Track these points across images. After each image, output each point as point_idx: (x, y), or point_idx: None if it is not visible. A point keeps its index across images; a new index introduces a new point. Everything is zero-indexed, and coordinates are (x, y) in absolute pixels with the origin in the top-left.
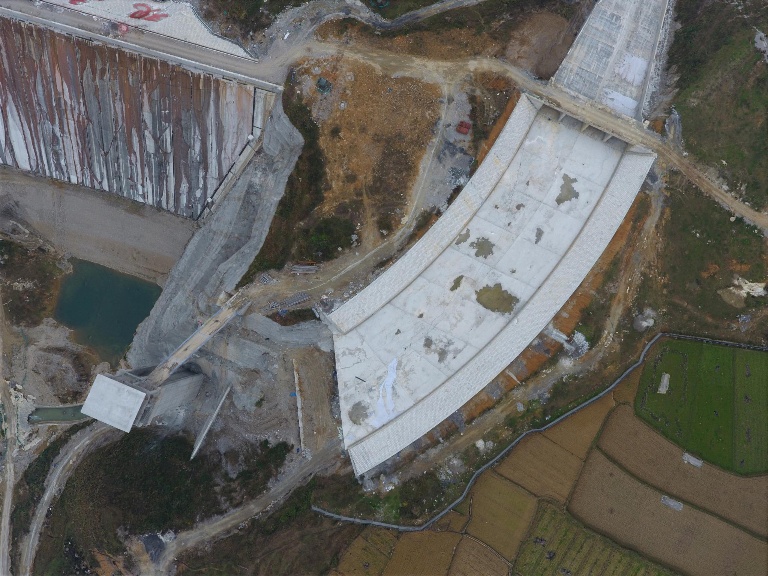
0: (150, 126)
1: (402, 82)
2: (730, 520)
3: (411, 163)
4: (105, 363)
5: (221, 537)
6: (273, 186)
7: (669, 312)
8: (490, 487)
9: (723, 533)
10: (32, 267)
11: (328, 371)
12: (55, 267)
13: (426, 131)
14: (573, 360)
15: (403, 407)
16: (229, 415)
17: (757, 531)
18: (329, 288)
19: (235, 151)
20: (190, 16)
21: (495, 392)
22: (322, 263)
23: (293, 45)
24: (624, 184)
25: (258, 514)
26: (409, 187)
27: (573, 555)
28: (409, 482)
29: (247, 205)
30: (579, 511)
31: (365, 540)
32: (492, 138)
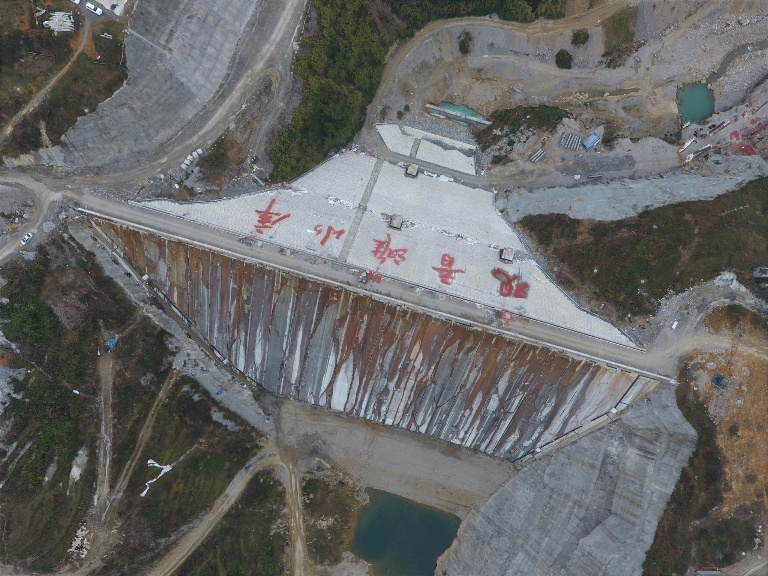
0: (501, 392)
1: None
2: None
3: None
4: None
5: None
6: (652, 472)
7: None
8: None
9: None
10: (332, 501)
11: None
12: (353, 499)
13: None
14: None
15: None
16: None
17: None
18: None
19: (588, 417)
20: (545, 282)
21: None
22: (724, 567)
23: (683, 336)
24: None
25: None
26: None
27: None
28: None
29: (604, 475)
30: None
31: None
32: None
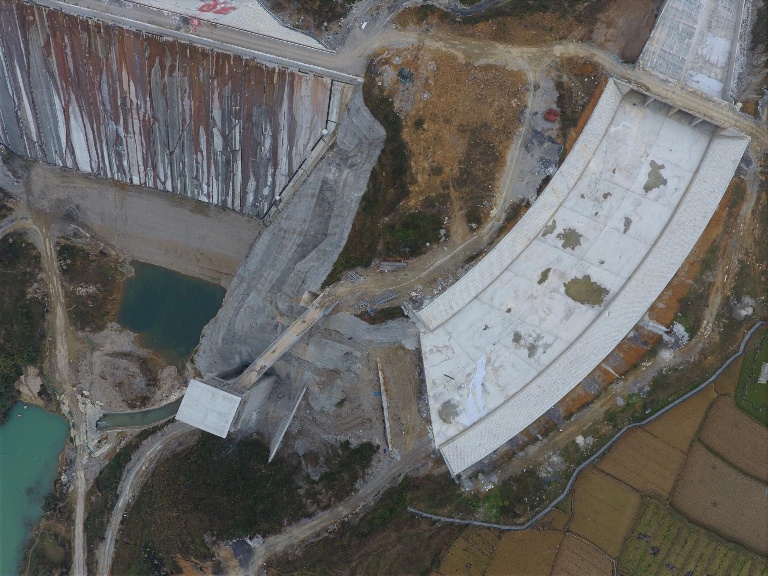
0: (219, 123)
1: (486, 70)
2: None
3: (498, 154)
4: (171, 367)
5: (311, 540)
6: (353, 181)
7: (767, 300)
8: (591, 483)
9: None
10: (94, 271)
11: (414, 369)
12: (117, 271)
13: (513, 120)
14: (673, 352)
15: (494, 404)
16: (305, 416)
17: None
18: (418, 285)
19: (307, 146)
20: (257, 8)
21: (592, 386)
22: (410, 259)
23: (371, 35)
24: (716, 169)
25: (347, 516)
26: (497, 178)
27: (677, 550)
28: (509, 481)
29: (322, 202)
30: (682, 505)
31: (466, 540)
32: (580, 125)
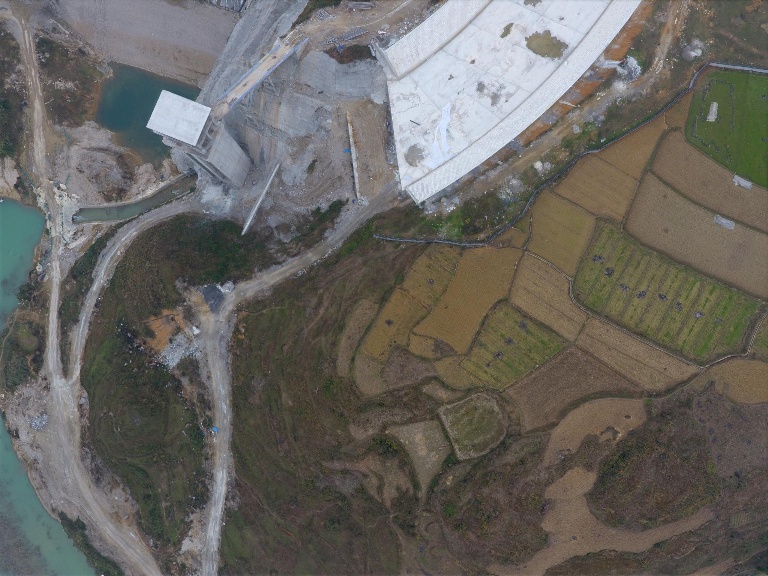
0: None
1: None
2: None
3: None
4: (148, 164)
5: (281, 282)
6: None
7: (716, 44)
8: (549, 206)
9: None
10: (73, 69)
11: (382, 121)
12: (95, 70)
13: None
14: (626, 83)
15: (458, 149)
16: (278, 193)
17: None
18: (385, 24)
19: None
20: None
21: (551, 118)
22: None
23: None
24: None
25: (316, 261)
26: None
27: (631, 271)
28: (470, 200)
29: None
30: (635, 231)
31: (429, 258)
32: None
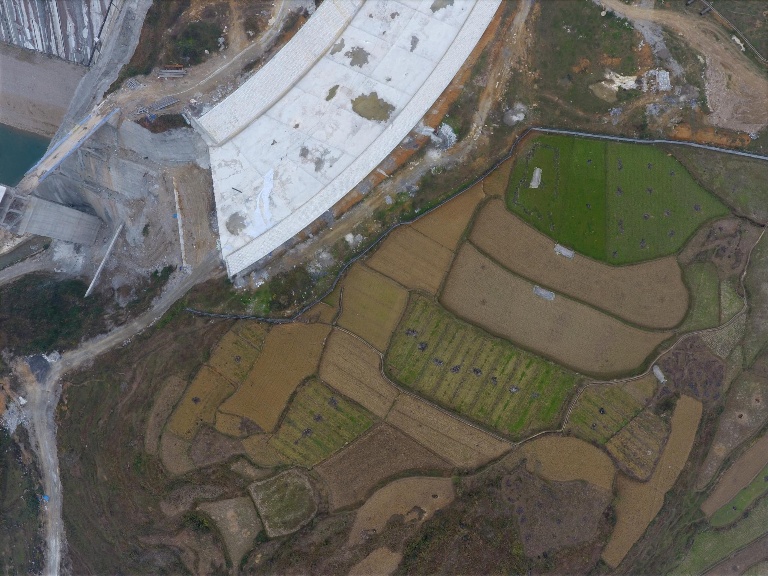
0: None
1: None
2: (602, 309)
3: None
4: None
5: (104, 353)
6: (144, 1)
7: (540, 107)
8: (360, 280)
9: (595, 321)
10: None
11: (207, 187)
12: None
13: None
14: (441, 152)
15: (280, 216)
16: (123, 253)
17: (629, 319)
18: (198, 92)
19: None
20: None
21: (365, 188)
22: (190, 67)
23: None
24: None
25: (141, 331)
26: None
27: (445, 345)
28: (278, 275)
29: (126, 31)
30: (451, 304)
31: (236, 334)
32: None
